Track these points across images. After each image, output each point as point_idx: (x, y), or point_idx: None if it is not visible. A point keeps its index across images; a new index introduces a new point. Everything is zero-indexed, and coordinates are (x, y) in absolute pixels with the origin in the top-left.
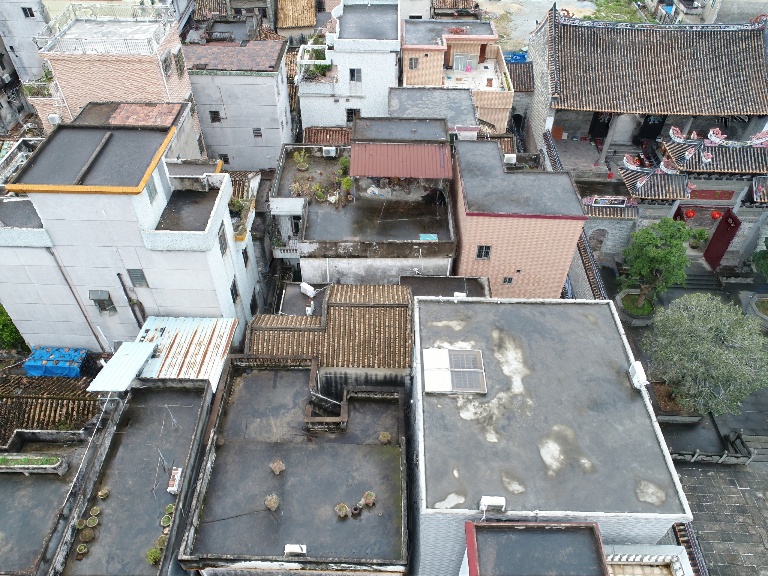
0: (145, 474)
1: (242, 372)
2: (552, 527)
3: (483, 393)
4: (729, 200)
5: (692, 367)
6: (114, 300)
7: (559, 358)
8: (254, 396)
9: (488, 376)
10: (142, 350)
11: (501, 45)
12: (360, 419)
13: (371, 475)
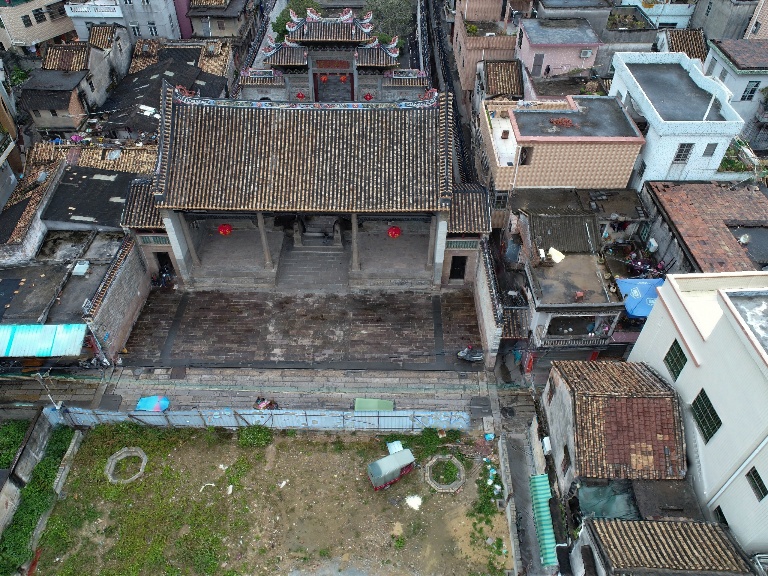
0: None
1: None
2: None
3: None
4: None
5: None
6: None
7: None
8: None
9: None
10: None
11: (447, 570)
12: None
13: None
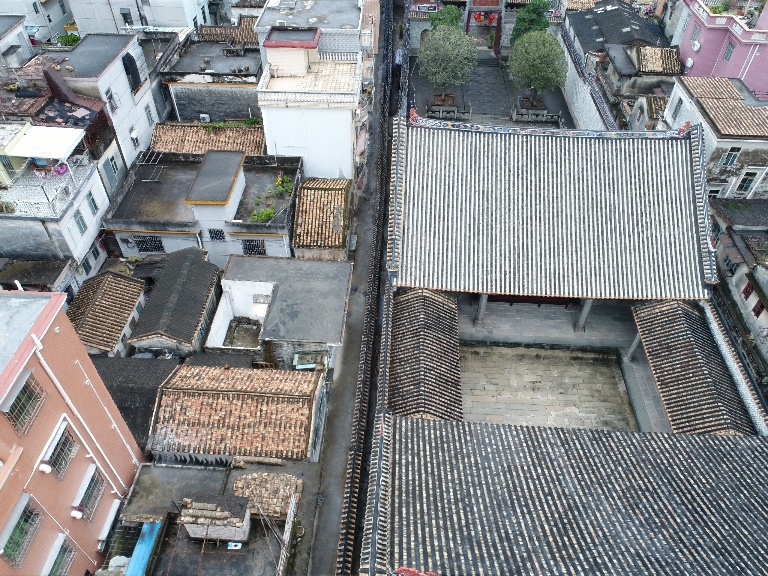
0: (146, 59)
1: (196, 43)
2: (302, 28)
3: (292, 8)
4: (498, 6)
5: (429, 53)
6: (132, 15)
7: (331, 2)
8: (200, 49)
9: (297, 5)
10: (146, 26)
11: None
12: (250, 55)
13: (250, 64)
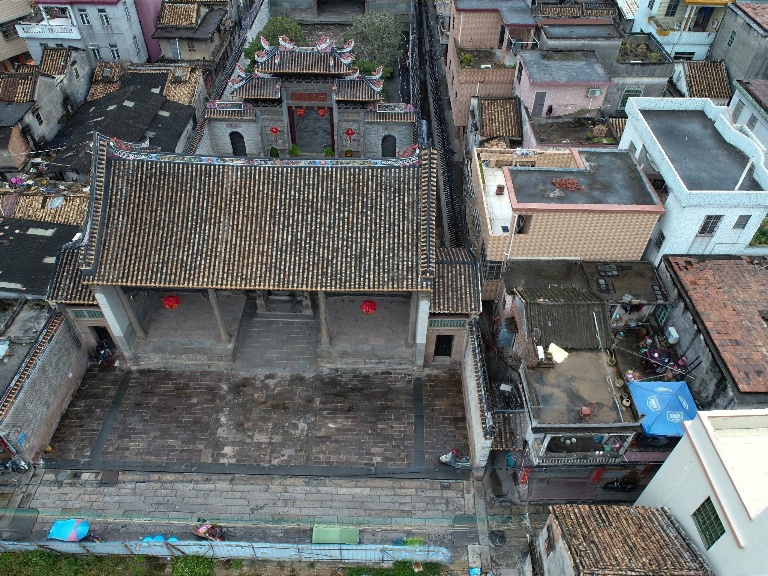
0: None
1: None
2: None
3: None
4: None
5: None
6: None
7: None
8: None
9: None
10: None
11: None
12: None
13: None
